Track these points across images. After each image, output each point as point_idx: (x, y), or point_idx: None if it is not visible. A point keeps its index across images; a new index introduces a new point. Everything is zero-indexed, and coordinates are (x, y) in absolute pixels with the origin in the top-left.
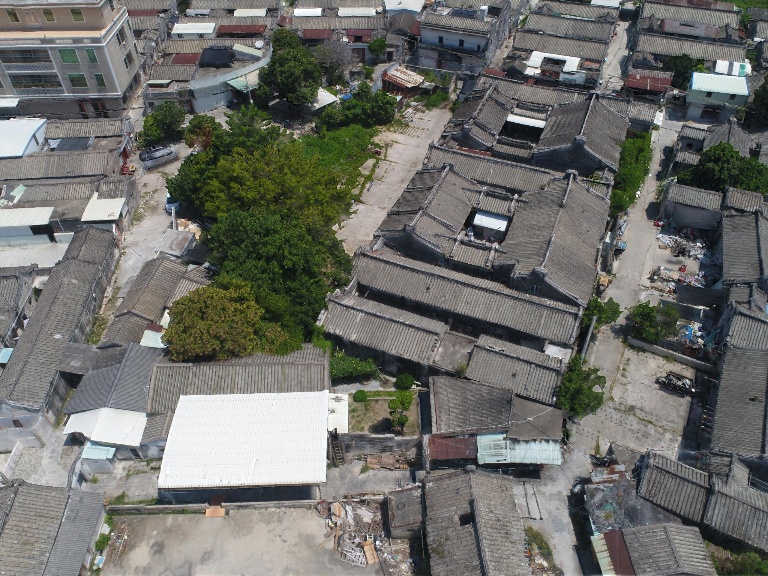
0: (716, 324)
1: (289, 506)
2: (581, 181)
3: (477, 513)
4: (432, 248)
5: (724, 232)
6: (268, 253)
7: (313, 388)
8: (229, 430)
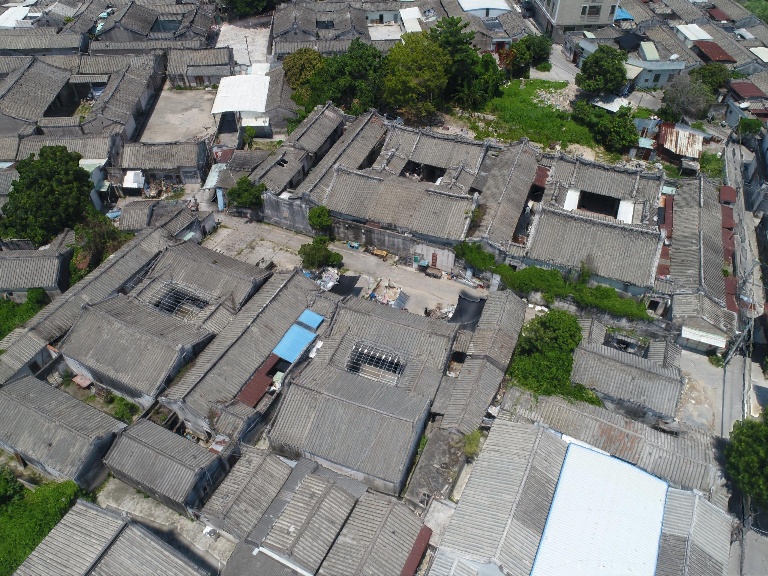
0: None
1: None
2: None
3: None
4: None
5: None
6: None
7: None
8: None
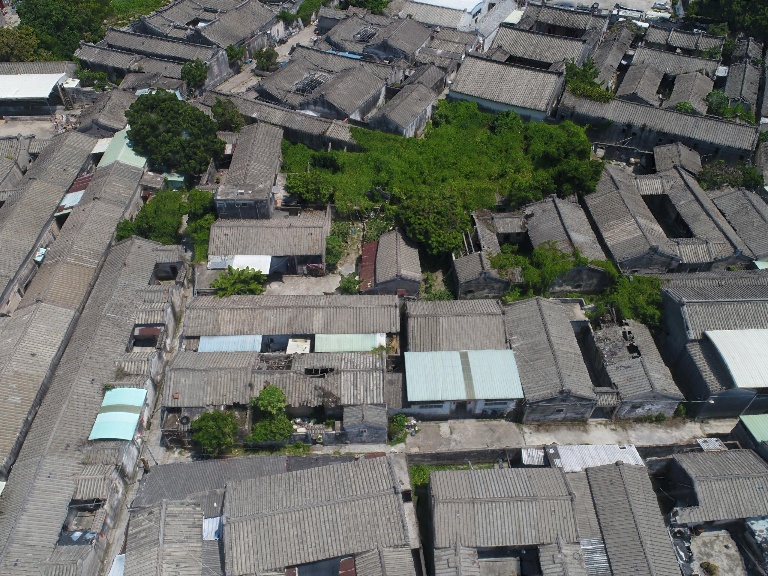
0: None
1: (38, 120)
2: (265, 4)
3: (108, 96)
4: (156, 29)
5: None
6: (44, 13)
7: (58, 72)
8: (8, 82)
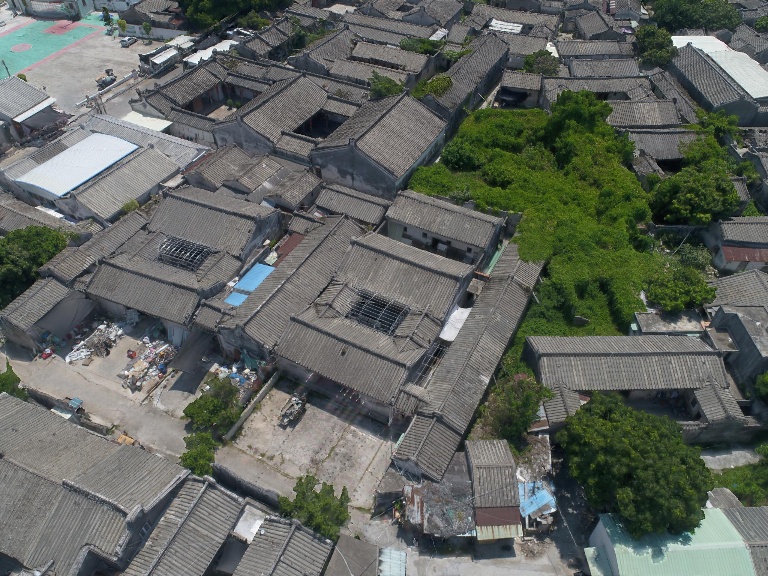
0: (221, 351)
1: None
2: None
3: None
4: None
5: (110, 298)
6: None
7: None
8: None
